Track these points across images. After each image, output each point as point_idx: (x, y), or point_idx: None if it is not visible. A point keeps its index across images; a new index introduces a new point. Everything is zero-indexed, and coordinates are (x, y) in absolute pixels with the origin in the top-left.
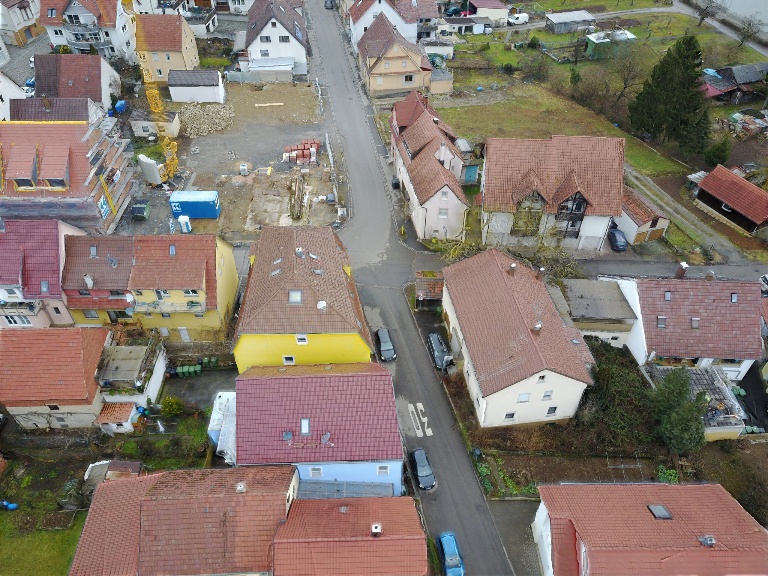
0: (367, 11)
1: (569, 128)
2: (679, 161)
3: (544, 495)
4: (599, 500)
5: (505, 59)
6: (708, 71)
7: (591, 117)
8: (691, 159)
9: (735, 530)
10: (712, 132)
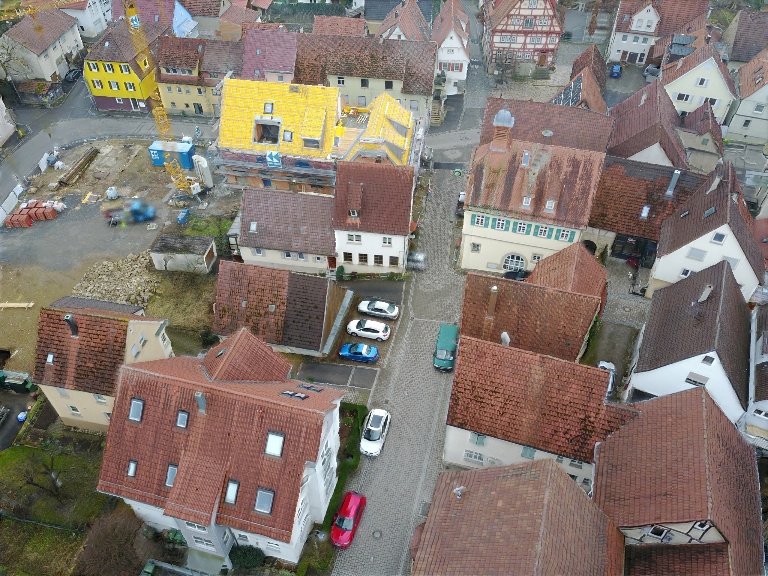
0: None
1: None
2: None
3: (85, 5)
4: None
5: None
6: None
7: None
8: None
9: None
10: None
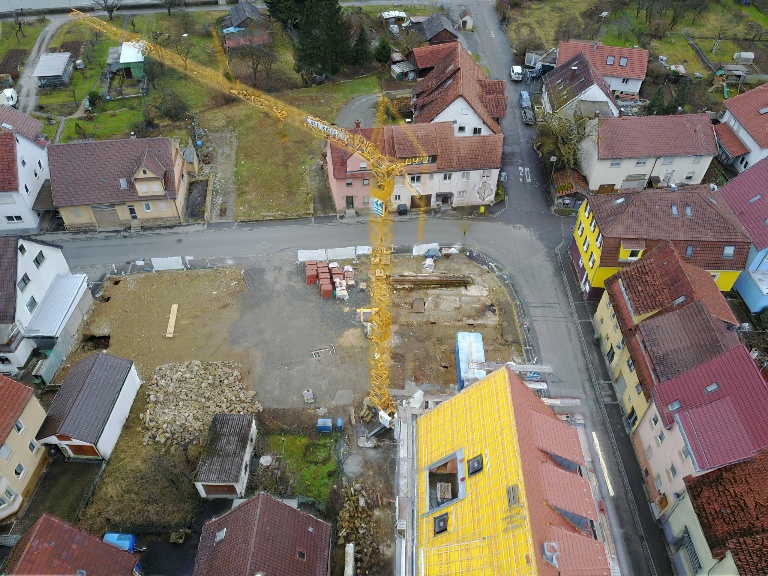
0: (17, 162)
1: (301, 109)
2: (360, 76)
3: None
4: (764, 128)
5: (116, 124)
6: (229, 31)
7: (284, 95)
8: (356, 72)
9: (767, 91)
10: (371, 40)
